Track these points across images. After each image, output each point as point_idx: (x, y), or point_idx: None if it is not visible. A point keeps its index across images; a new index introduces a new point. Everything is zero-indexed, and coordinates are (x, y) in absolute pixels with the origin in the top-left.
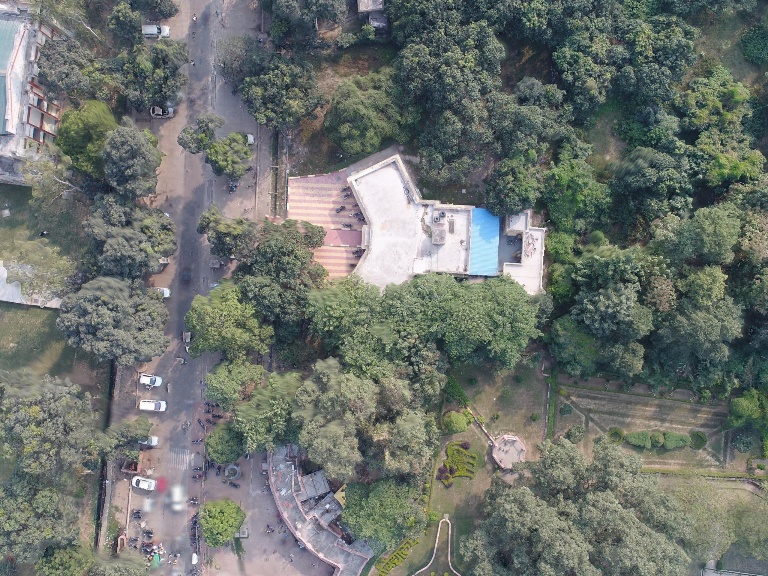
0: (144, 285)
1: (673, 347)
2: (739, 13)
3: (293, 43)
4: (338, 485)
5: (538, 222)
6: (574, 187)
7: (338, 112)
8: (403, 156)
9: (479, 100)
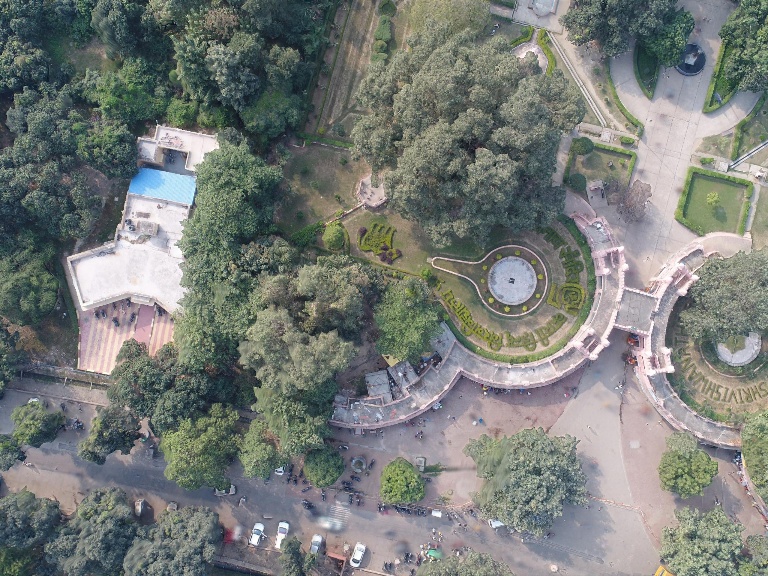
0: (148, 526)
1: (282, 18)
2: None
3: None
4: (385, 362)
5: None
6: (120, 92)
7: (7, 310)
8: (74, 254)
9: None
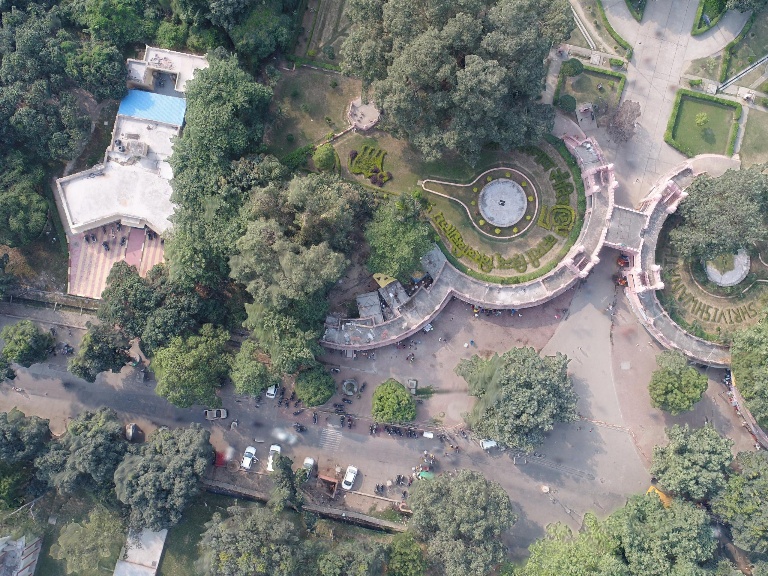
0: (139, 444)
1: None
2: None
3: None
4: None
5: None
6: (109, 12)
7: None
8: None
9: None
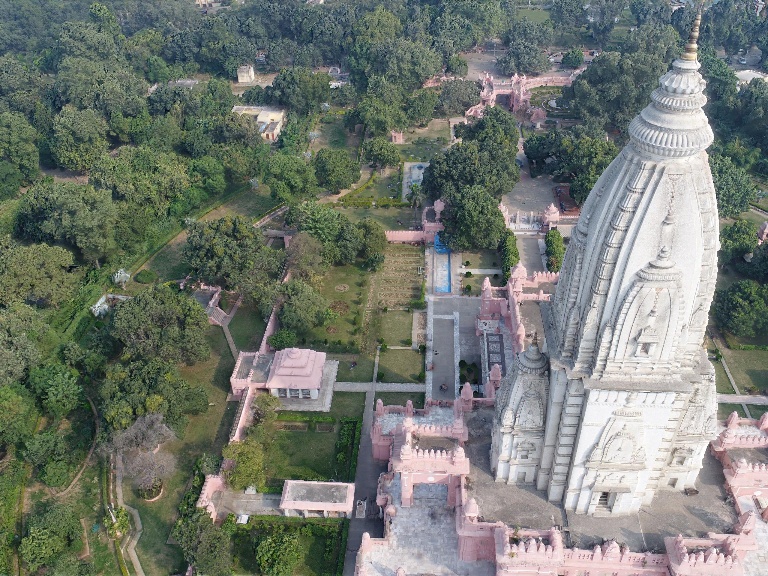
0: None
1: None
2: None
3: None
4: None
5: None
6: None
7: None
8: None
9: None
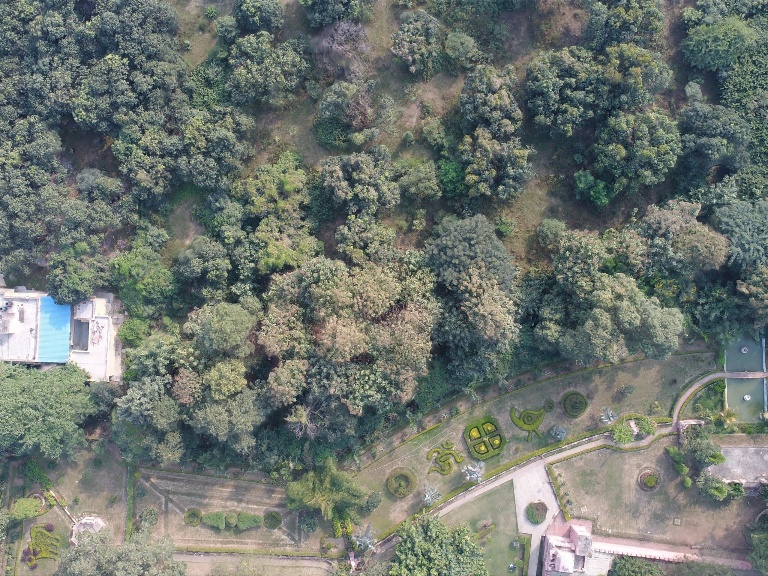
0: None
1: None
2: (312, 98)
3: None
4: None
5: (118, 307)
6: (134, 276)
7: None
8: None
9: (29, 194)
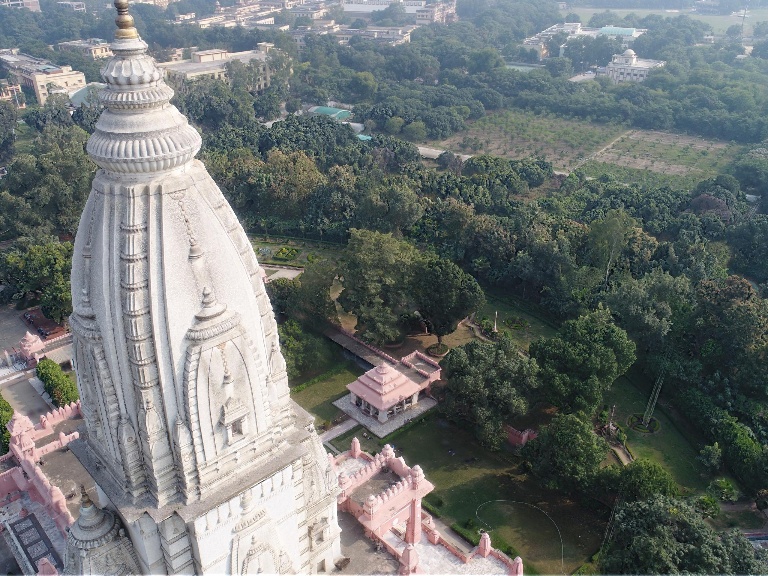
0: None
1: None
2: None
3: (203, 128)
4: None
5: None
6: None
7: None
8: None
9: None
